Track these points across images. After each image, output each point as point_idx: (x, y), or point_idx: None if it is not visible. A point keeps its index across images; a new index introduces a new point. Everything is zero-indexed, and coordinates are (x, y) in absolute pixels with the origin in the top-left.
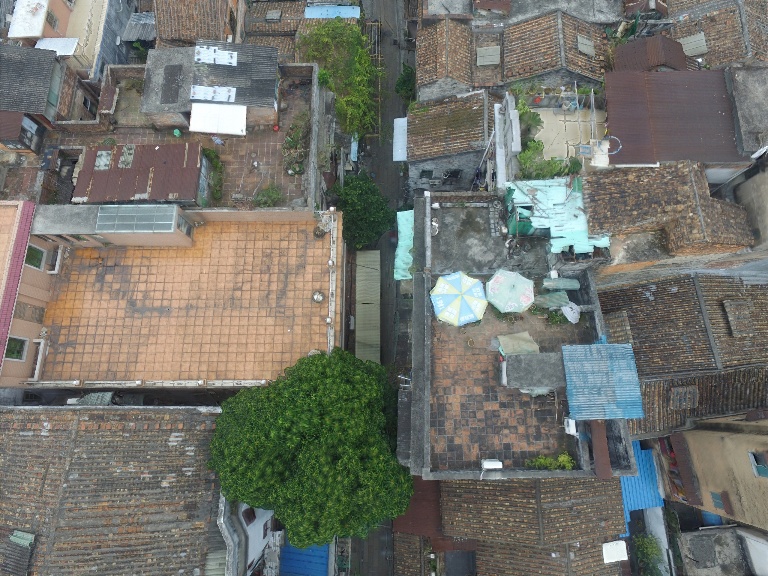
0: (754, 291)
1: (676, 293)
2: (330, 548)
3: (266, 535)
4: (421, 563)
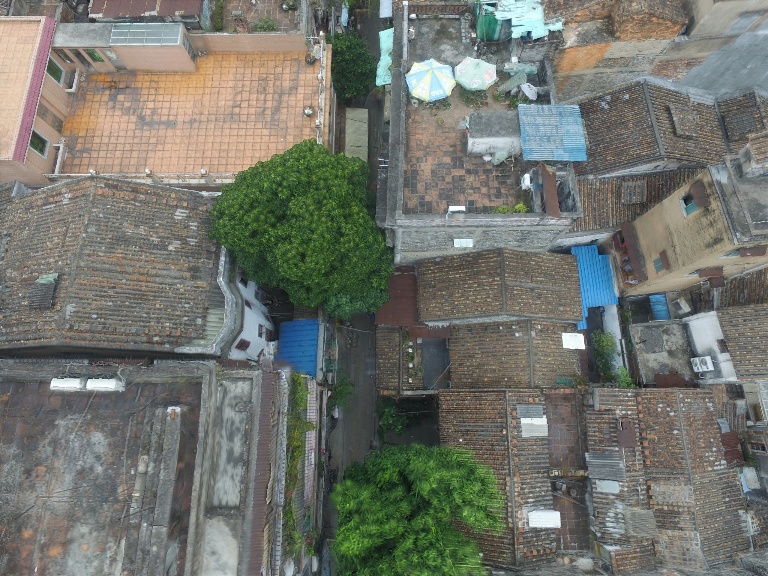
0: (700, 108)
1: (627, 99)
2: (318, 345)
3: (261, 338)
4: (400, 354)
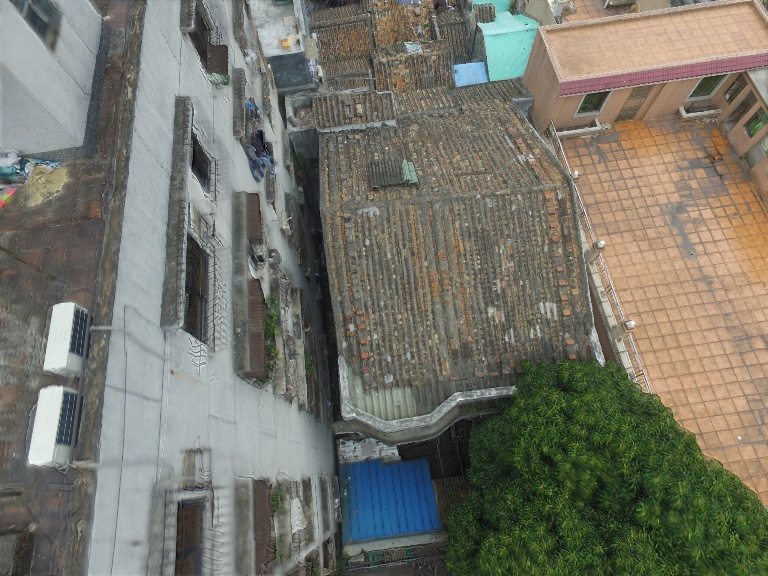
0: None
1: None
2: (399, 539)
3: None
4: None
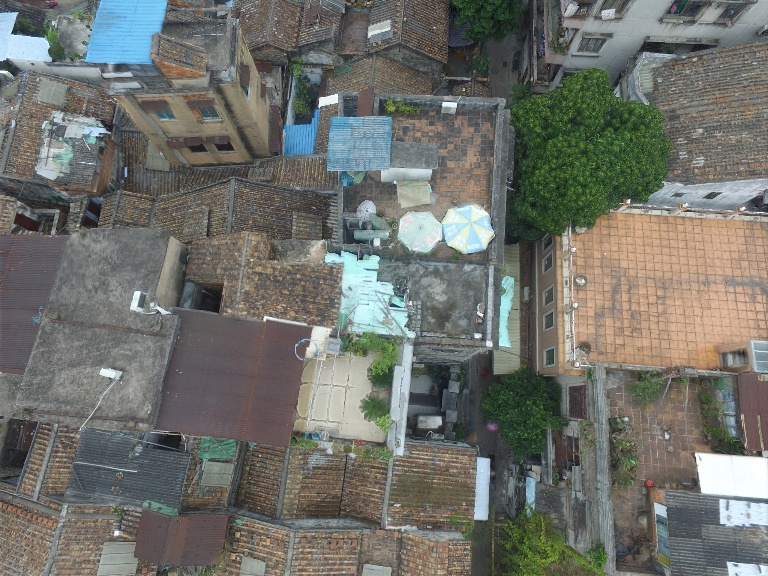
0: None
1: None
2: None
3: None
4: None
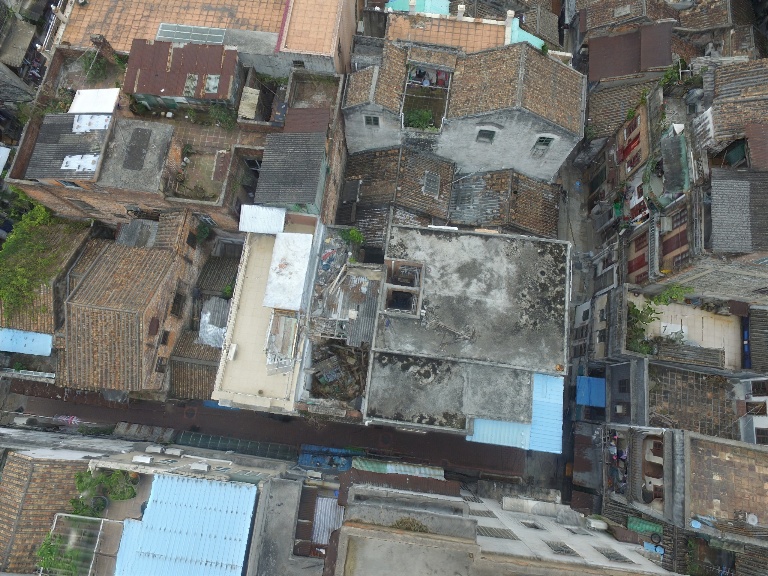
0: None
1: None
2: None
3: None
4: None
